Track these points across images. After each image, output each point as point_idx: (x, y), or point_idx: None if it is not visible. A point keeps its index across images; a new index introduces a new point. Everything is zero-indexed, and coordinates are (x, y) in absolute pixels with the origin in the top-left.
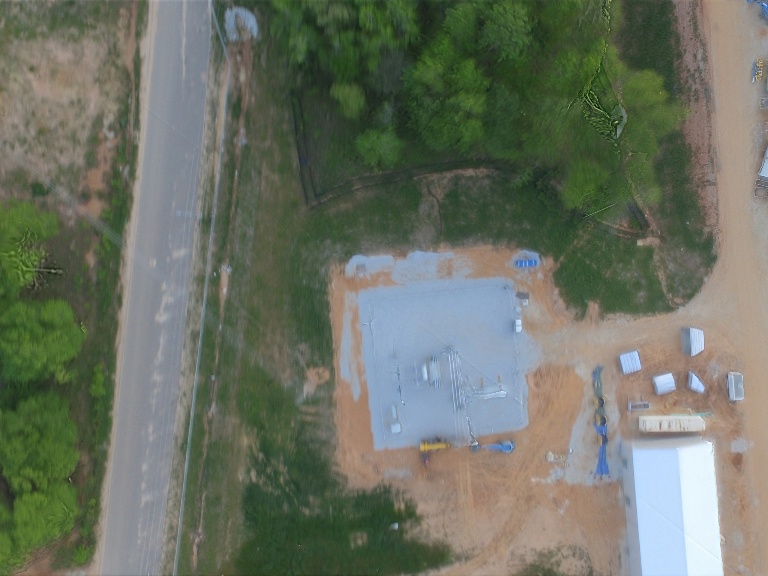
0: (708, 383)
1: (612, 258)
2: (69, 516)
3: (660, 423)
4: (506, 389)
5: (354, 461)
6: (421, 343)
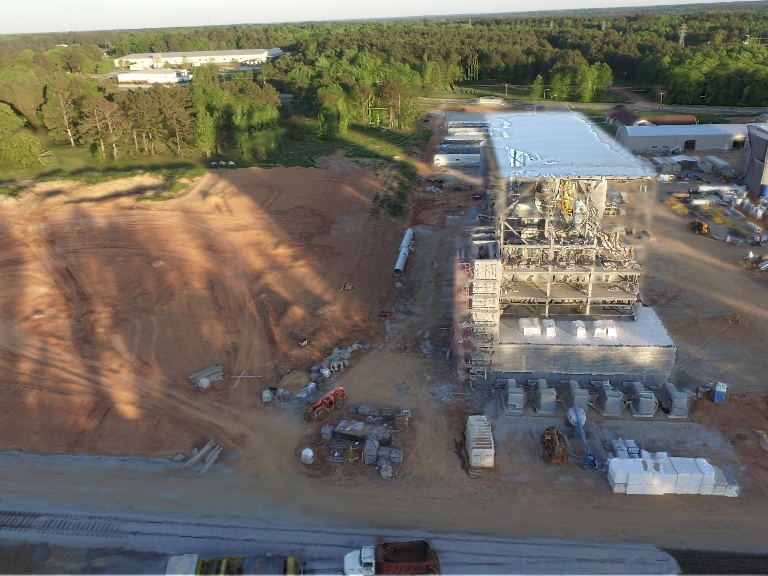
0: None
1: None
2: (692, 88)
3: None
4: None
5: None
6: None
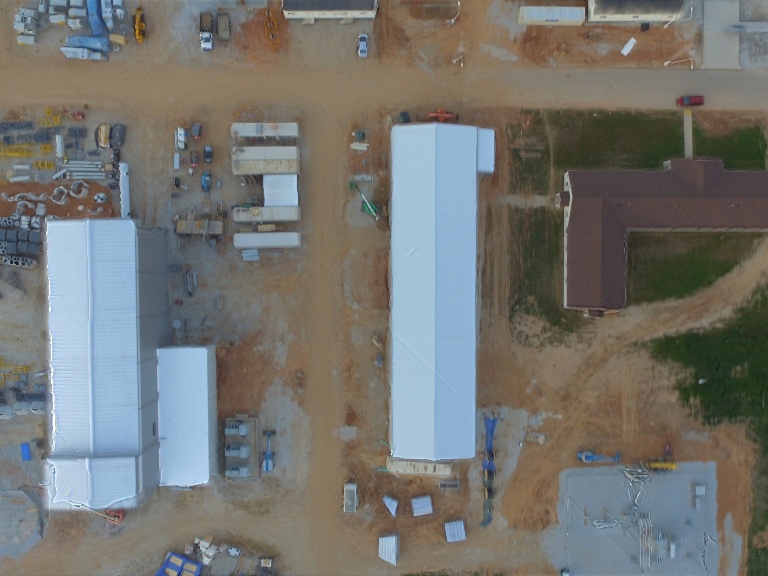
0: (375, 500)
1: None
2: None
3: (435, 472)
4: (581, 512)
5: (738, 452)
6: (662, 567)
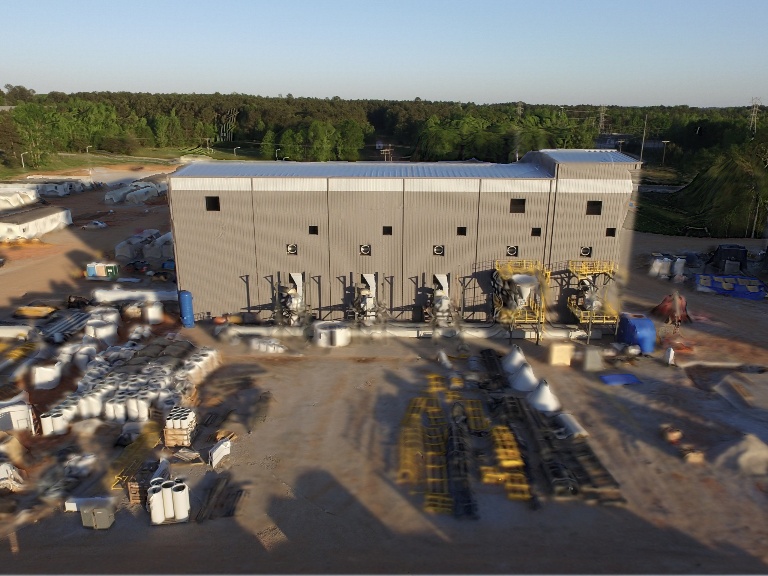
0: None
1: (655, 231)
2: (445, 152)
3: None
4: None
5: None
6: None
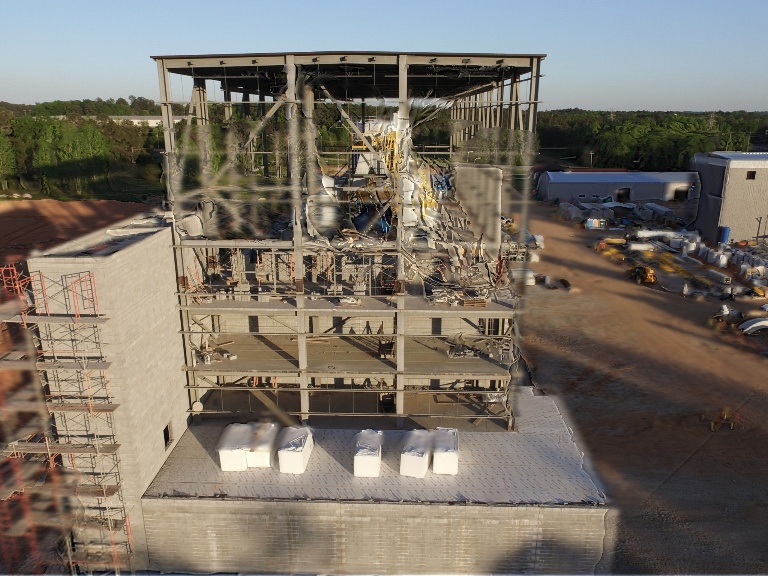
0: None
1: None
2: (625, 152)
3: None
4: None
5: None
6: None
